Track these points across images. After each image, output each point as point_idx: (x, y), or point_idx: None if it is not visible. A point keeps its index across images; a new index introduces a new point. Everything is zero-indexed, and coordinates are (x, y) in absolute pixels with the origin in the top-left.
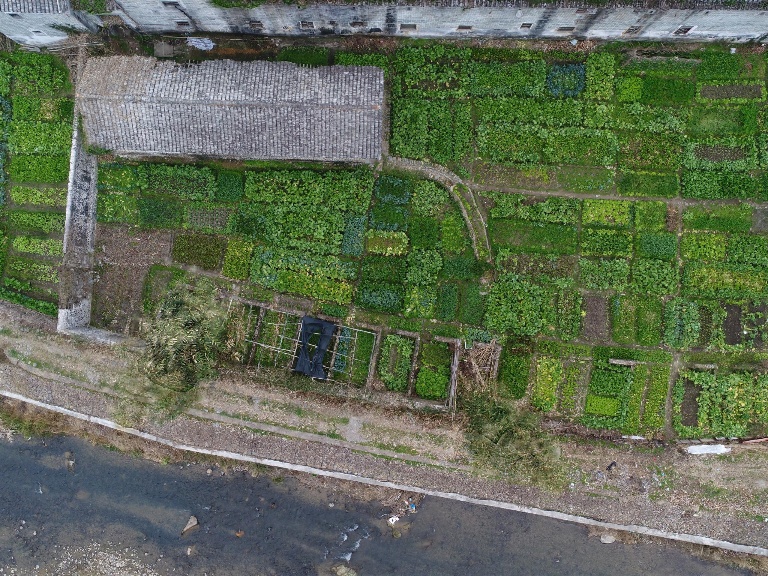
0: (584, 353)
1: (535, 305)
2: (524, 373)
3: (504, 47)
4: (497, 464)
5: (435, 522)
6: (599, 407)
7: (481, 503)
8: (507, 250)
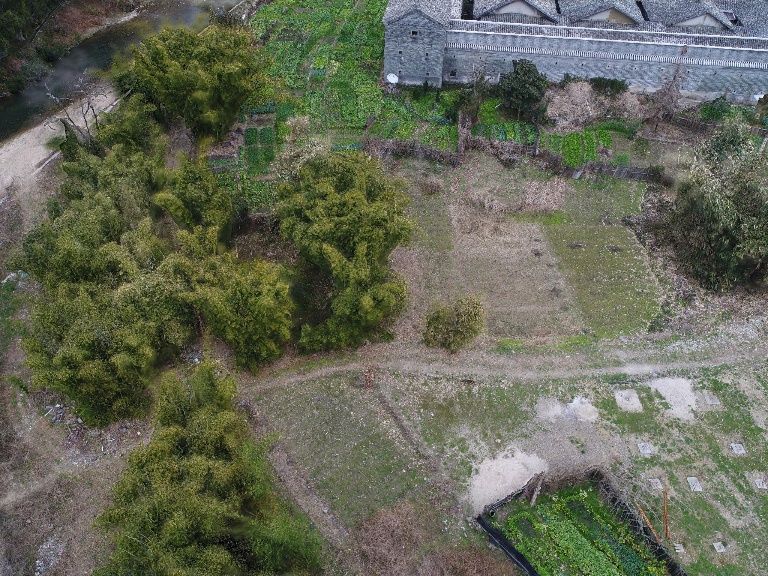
0: (292, 6)
1: None
2: None
3: None
4: None
5: (240, 0)
6: (270, 8)
7: (243, 0)
8: None
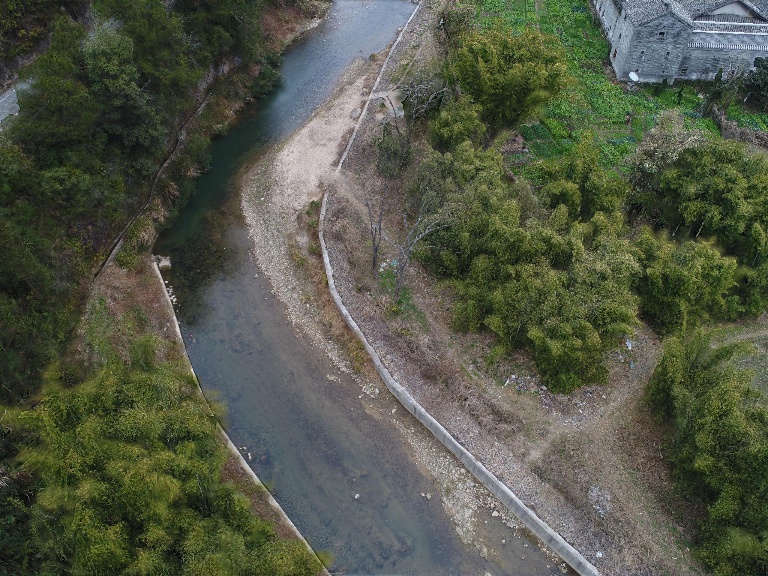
0: None
1: (494, 4)
2: (469, 2)
3: (588, 2)
4: (435, 2)
5: None
6: None
7: None
8: (514, 1)
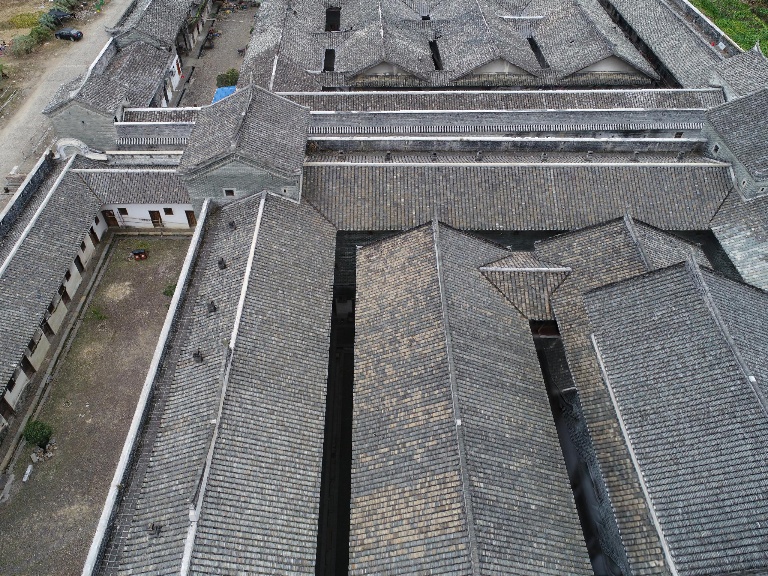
0: None
1: None
2: None
3: None
4: None
5: None
6: None
7: None
8: None
